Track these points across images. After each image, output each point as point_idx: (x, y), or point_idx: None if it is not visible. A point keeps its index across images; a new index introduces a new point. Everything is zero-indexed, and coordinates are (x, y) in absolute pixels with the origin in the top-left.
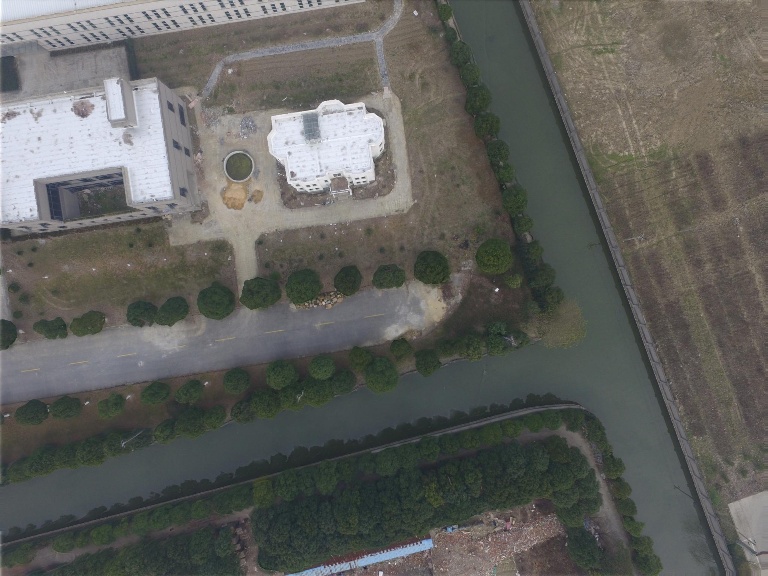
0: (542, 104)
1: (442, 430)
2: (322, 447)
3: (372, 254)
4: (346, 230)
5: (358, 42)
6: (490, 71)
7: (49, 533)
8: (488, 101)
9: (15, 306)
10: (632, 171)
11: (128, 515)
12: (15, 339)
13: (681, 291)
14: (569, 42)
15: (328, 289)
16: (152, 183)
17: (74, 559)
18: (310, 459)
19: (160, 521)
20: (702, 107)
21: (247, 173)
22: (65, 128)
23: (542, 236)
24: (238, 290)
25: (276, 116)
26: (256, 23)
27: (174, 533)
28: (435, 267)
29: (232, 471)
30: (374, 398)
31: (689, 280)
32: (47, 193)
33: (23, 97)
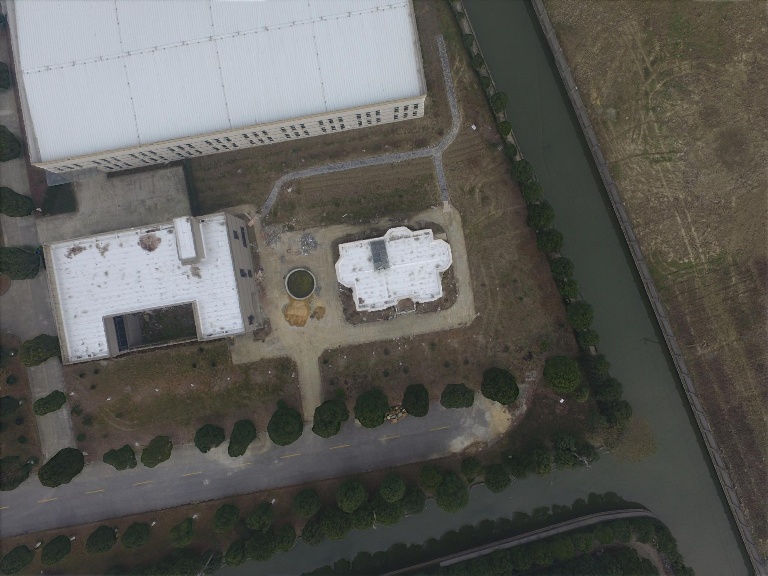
0: (598, 209)
1: (509, 539)
2: (385, 552)
3: (436, 368)
4: (409, 345)
5: (417, 157)
6: (550, 184)
7: None
8: (552, 219)
9: (78, 428)
10: (692, 278)
11: None
12: None
13: (744, 396)
14: (626, 151)
15: (393, 403)
16: (221, 315)
17: None
18: (377, 570)
19: None
20: (760, 213)
21: (308, 290)
22: (132, 262)
23: (608, 351)
24: (302, 406)
25: (343, 244)
26: (314, 140)
27: None
28: (507, 392)
29: None
30: (443, 514)
31: (751, 385)
32: (114, 326)
33: (81, 219)
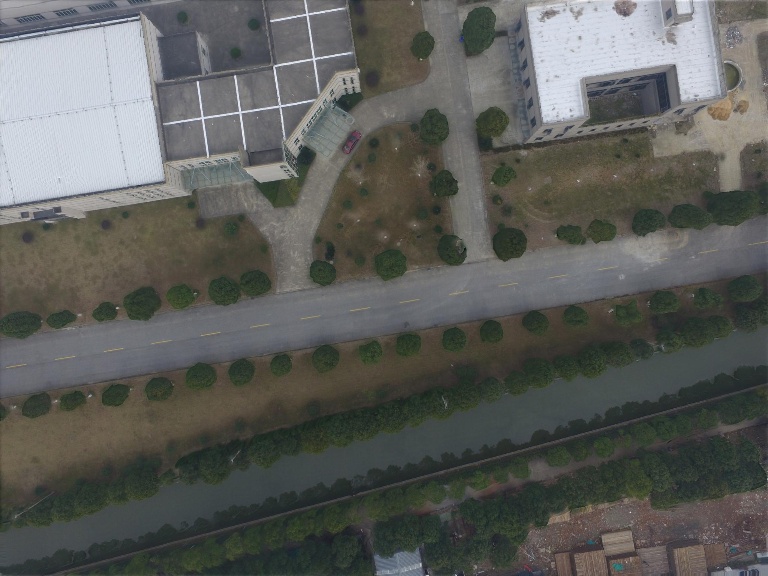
0: None
1: None
2: (767, 366)
3: None
4: None
5: None
6: None
7: (521, 451)
8: None
9: (494, 219)
10: None
11: (609, 430)
12: None
13: None
14: None
15: None
16: (696, 83)
17: (575, 472)
18: None
19: (674, 430)
20: None
21: (732, 83)
22: (607, 27)
23: None
24: None
25: None
26: None
27: (672, 445)
28: None
29: (674, 392)
30: None
31: None
32: None
33: None
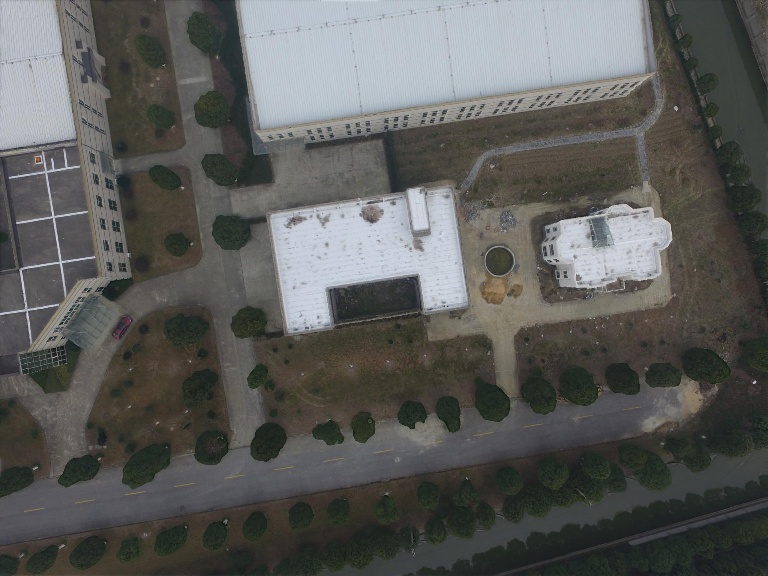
0: None
1: (695, 519)
2: (559, 532)
3: (632, 348)
4: (606, 324)
5: (620, 137)
6: None
7: None
8: (760, 201)
9: (268, 403)
10: None
11: None
12: None
13: None
14: None
15: None
16: (443, 289)
17: None
18: (560, 549)
19: None
20: None
21: (506, 267)
22: (354, 234)
23: None
24: (496, 384)
25: (565, 220)
26: (516, 117)
27: None
28: (723, 370)
29: (468, 558)
30: (639, 493)
31: None
32: (330, 298)
33: None
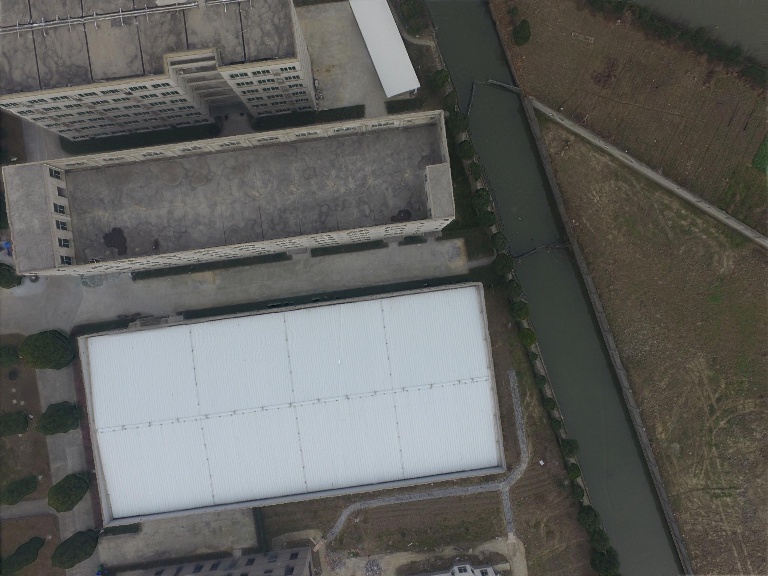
0: (656, 527)
1: None
2: None
3: None
4: None
5: (485, 491)
6: (614, 523)
7: None
8: None
9: None
10: None
11: None
12: None
13: None
14: (688, 485)
15: None
16: None
17: None
18: None
19: None
20: None
21: None
22: None
23: None
24: None
25: None
26: None
27: None
28: None
29: None
30: None
31: None
32: None
33: None
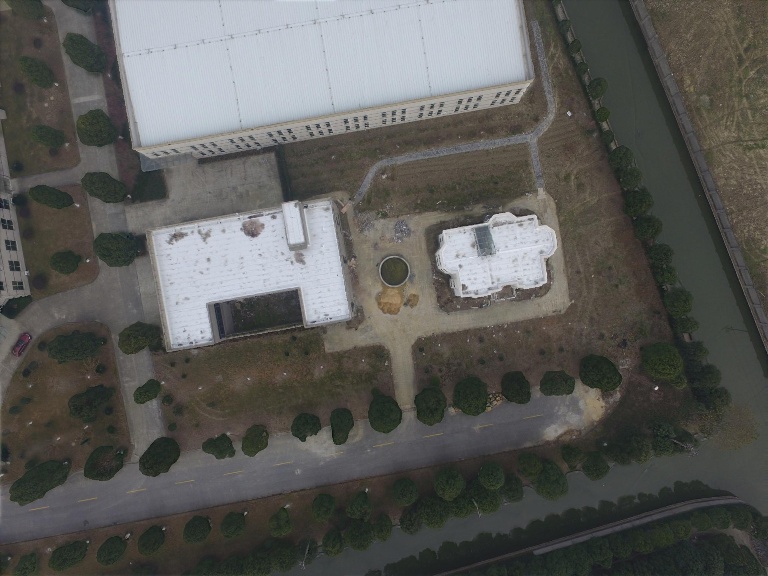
0: (688, 196)
1: (601, 527)
2: (471, 542)
3: (531, 356)
4: (504, 332)
5: (512, 144)
6: (646, 171)
7: None
8: (652, 205)
9: (168, 418)
10: None
11: None
12: (178, 457)
13: None
14: (720, 138)
15: None
16: (326, 302)
17: None
18: (467, 559)
19: None
20: None
21: (402, 277)
22: (235, 248)
23: (706, 337)
24: (395, 395)
25: (448, 230)
26: (408, 126)
27: None
28: (612, 378)
29: (380, 568)
30: (540, 502)
31: None
32: (215, 313)
33: (172, 206)
